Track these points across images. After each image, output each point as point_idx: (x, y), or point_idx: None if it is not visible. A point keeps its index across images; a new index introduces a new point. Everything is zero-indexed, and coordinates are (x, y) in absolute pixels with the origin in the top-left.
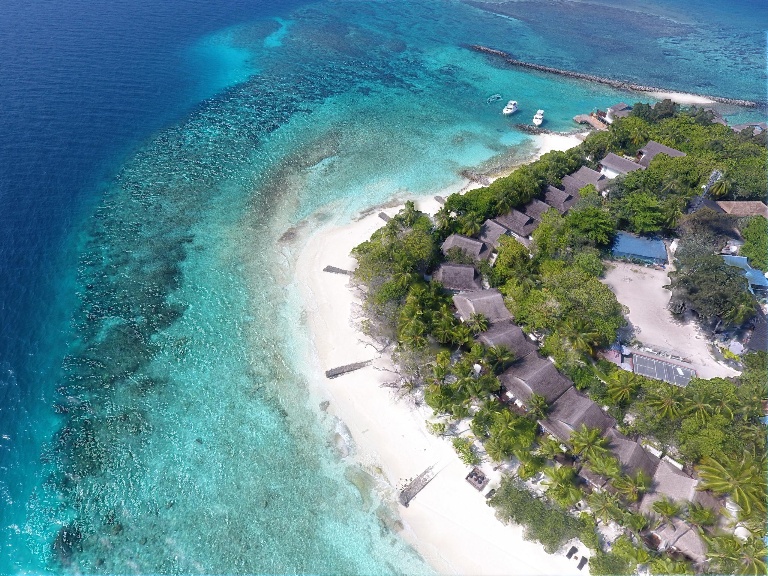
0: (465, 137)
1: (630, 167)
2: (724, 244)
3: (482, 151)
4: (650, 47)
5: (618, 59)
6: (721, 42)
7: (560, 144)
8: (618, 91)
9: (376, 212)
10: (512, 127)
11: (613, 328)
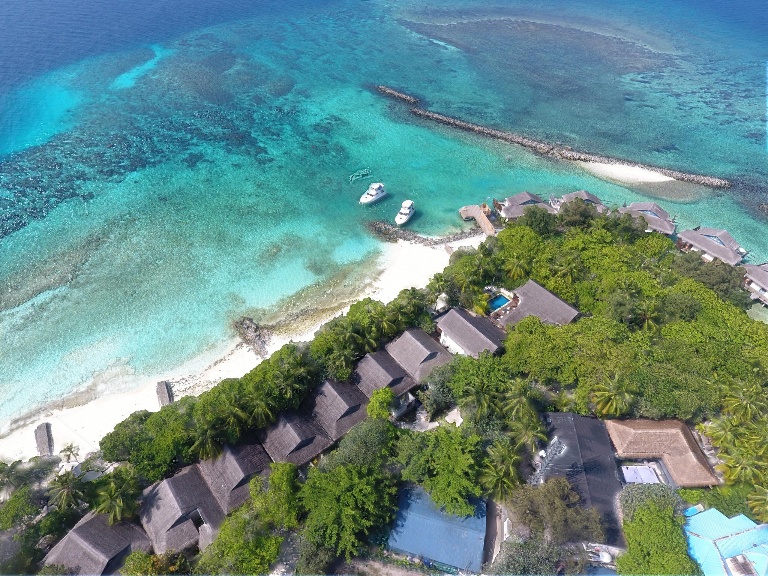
0: (285, 246)
1: (475, 342)
2: (577, 570)
3: (295, 275)
4: (609, 88)
5: (561, 107)
6: (703, 80)
7: (416, 262)
8: (542, 160)
9: (39, 419)
10: (363, 226)
11: None
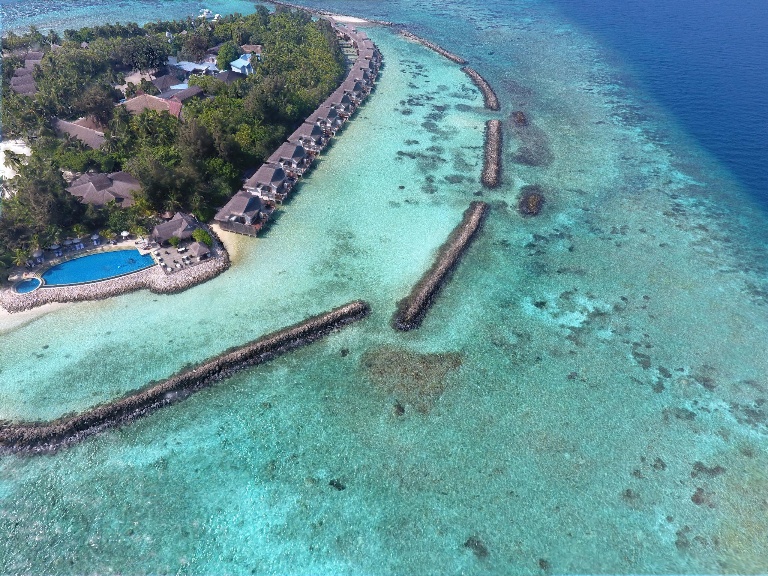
0: None
1: None
2: (199, 54)
3: None
4: None
5: (343, 1)
6: None
7: None
8: None
9: None
10: None
11: (72, 65)
